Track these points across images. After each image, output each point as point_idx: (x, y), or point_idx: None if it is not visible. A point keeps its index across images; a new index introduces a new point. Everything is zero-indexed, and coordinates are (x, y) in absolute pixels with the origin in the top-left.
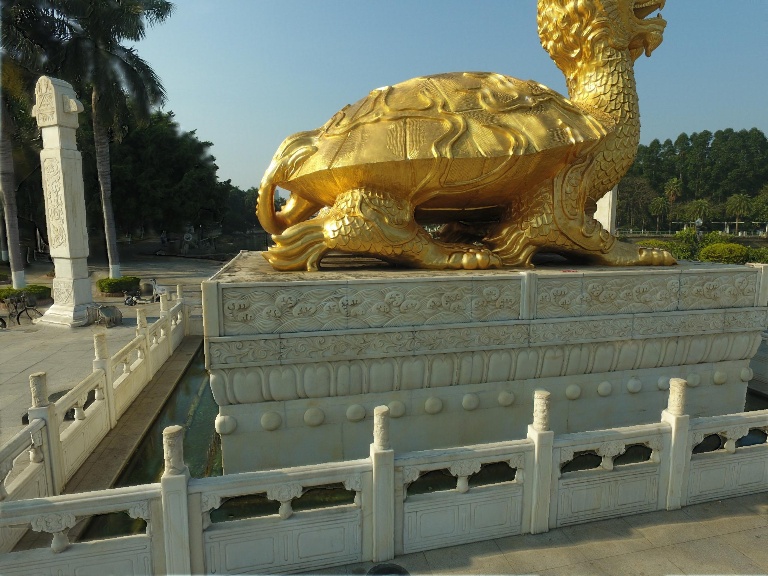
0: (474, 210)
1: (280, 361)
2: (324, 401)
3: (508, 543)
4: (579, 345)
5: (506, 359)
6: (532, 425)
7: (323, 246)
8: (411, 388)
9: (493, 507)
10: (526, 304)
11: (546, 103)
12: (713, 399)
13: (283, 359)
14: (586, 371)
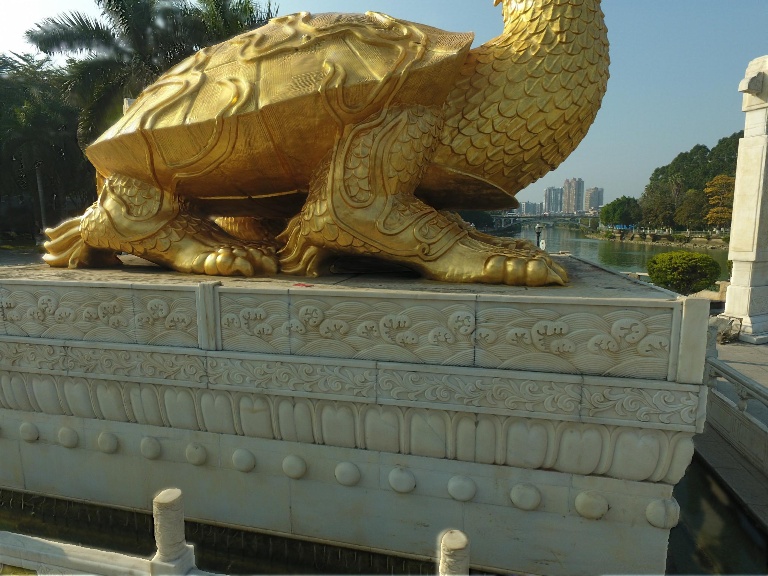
0: (270, 198)
1: None
2: None
3: None
4: (289, 398)
5: (183, 400)
6: None
7: None
8: (82, 416)
9: None
10: (202, 327)
11: (331, 39)
12: (578, 542)
13: None
14: (315, 440)
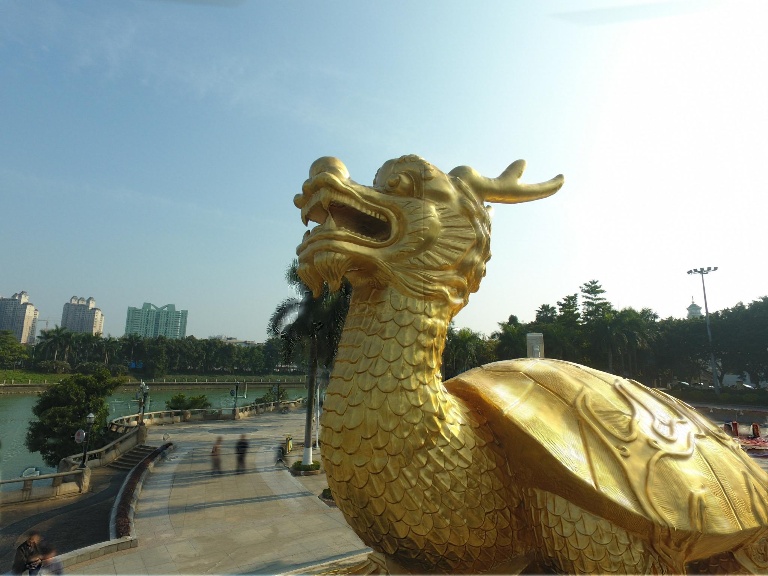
0: None
1: None
2: None
3: None
4: None
5: None
6: None
7: None
8: None
9: None
10: None
11: None
12: None
13: None
14: None
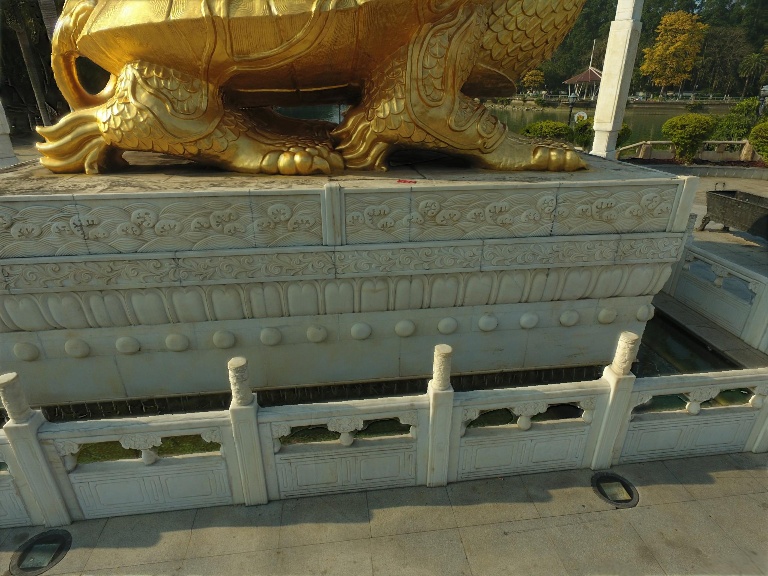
0: (316, 91)
1: (9, 290)
2: (85, 332)
3: (210, 515)
4: (408, 277)
5: (308, 291)
6: None
7: (101, 142)
8: (192, 321)
9: (190, 479)
10: (329, 226)
11: None
12: (596, 340)
13: (12, 288)
14: (423, 305)
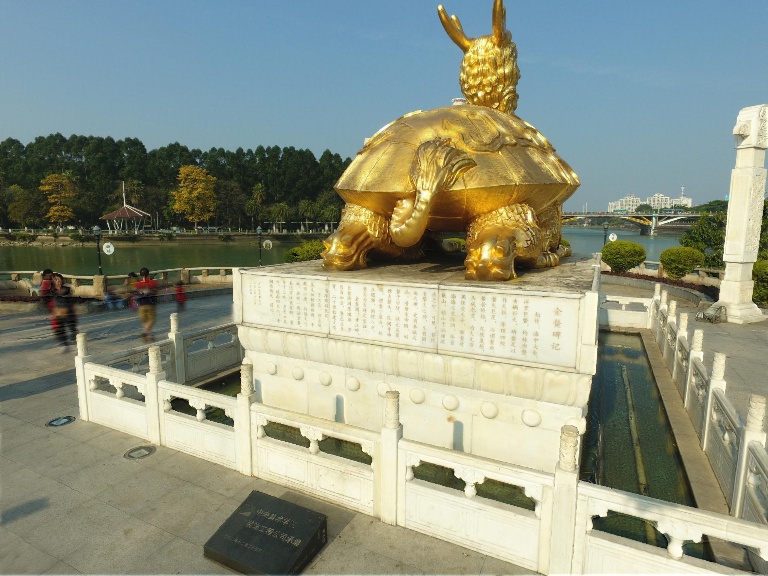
0: None
1: None
2: None
3: None
4: None
5: None
6: (694, 350)
7: (515, 254)
8: None
9: None
10: None
11: None
12: None
13: None
14: None
